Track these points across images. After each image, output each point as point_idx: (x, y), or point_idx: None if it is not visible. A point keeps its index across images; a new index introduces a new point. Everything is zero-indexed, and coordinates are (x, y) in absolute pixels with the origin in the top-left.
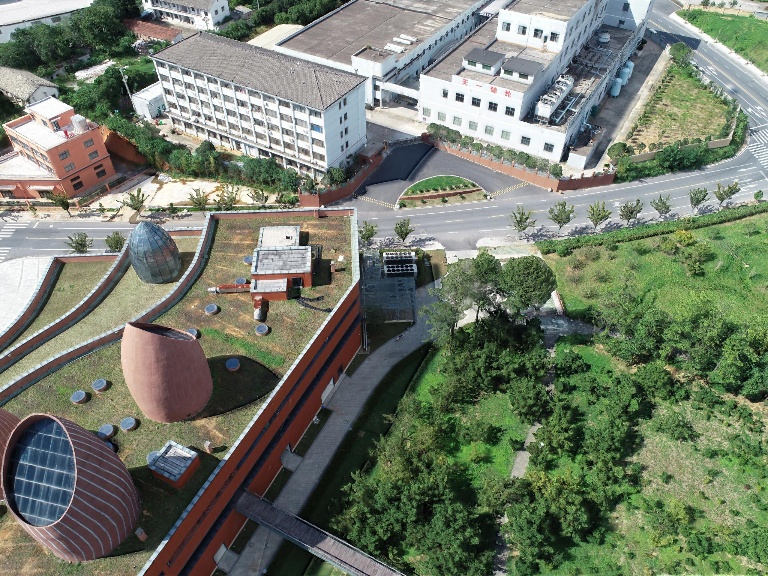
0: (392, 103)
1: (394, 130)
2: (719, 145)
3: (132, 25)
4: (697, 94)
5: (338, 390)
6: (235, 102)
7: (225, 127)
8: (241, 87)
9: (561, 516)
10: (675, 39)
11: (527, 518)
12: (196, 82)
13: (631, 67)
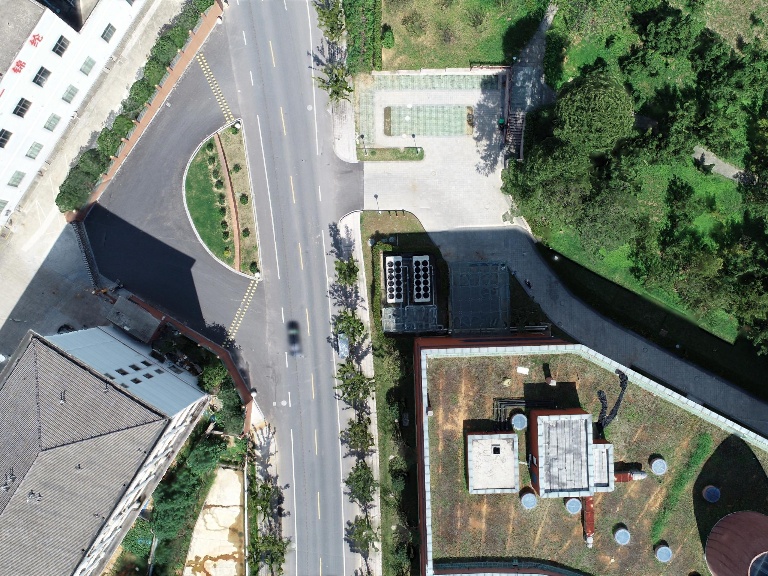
0: None
1: (39, 273)
2: None
3: None
4: None
5: None
6: None
7: None
8: None
9: None
10: None
11: None
12: None
13: None
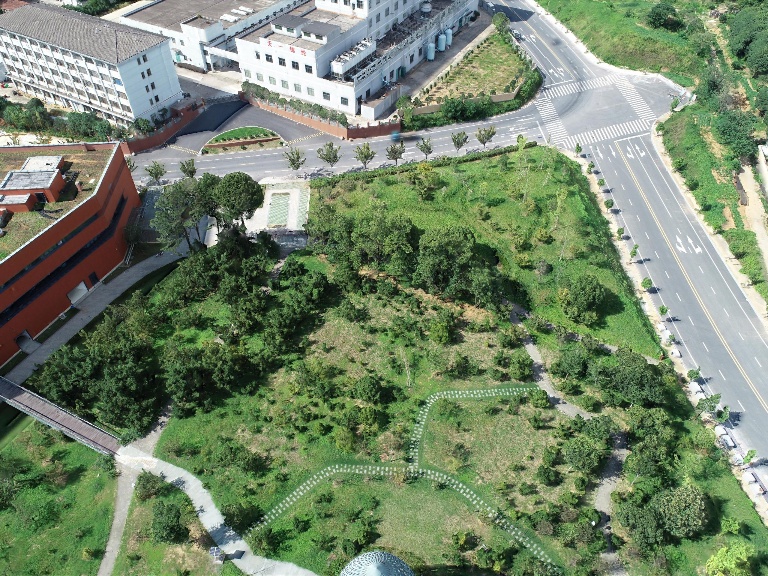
0: (225, 68)
1: (218, 90)
2: (504, 99)
3: (1, 2)
4: (506, 57)
5: (91, 294)
6: (54, 61)
7: (54, 86)
8: (55, 47)
9: (215, 371)
10: (511, 12)
11: (177, 369)
12: (22, 45)
13: (449, 34)
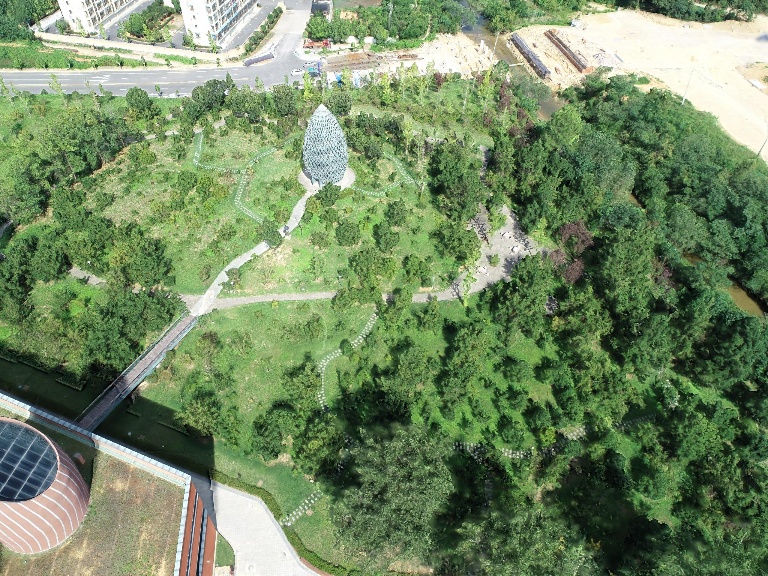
0: None
1: None
2: None
3: None
4: None
5: None
6: None
7: None
8: None
9: None
10: None
11: None
12: None
13: None
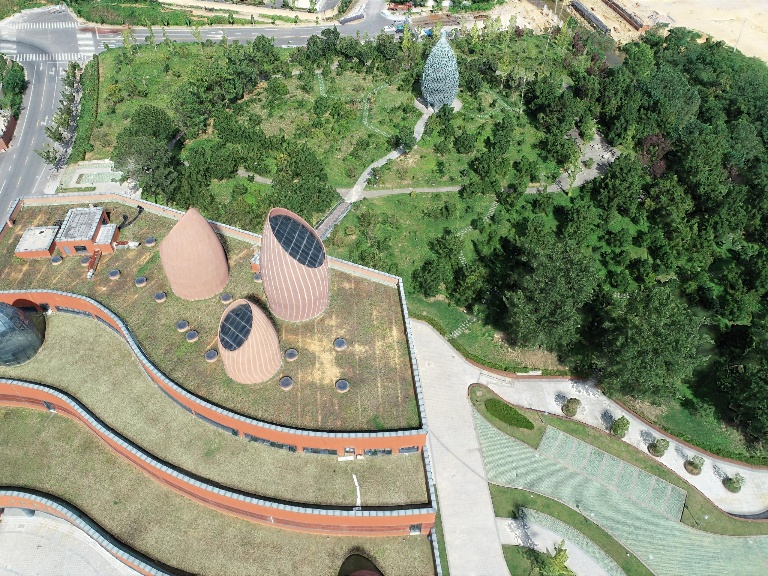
0: None
1: None
2: (10, 66)
3: None
4: None
5: None
6: None
7: None
8: None
9: None
10: None
11: None
12: None
13: None
